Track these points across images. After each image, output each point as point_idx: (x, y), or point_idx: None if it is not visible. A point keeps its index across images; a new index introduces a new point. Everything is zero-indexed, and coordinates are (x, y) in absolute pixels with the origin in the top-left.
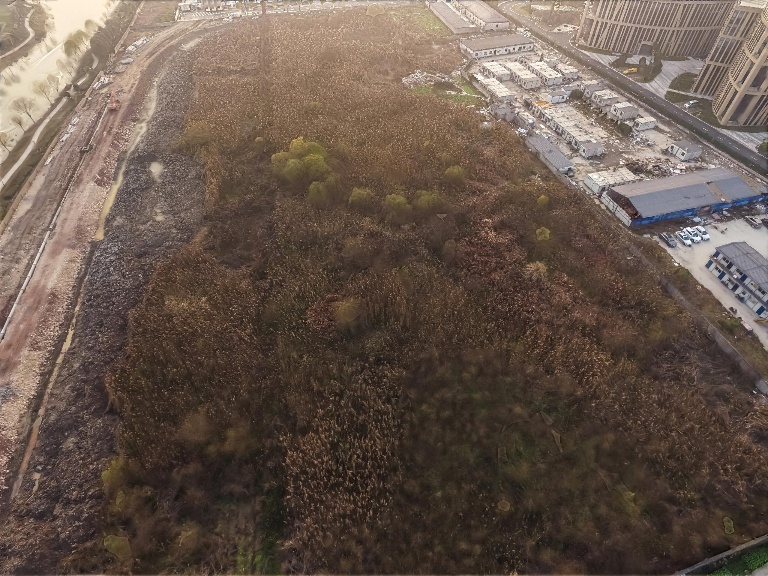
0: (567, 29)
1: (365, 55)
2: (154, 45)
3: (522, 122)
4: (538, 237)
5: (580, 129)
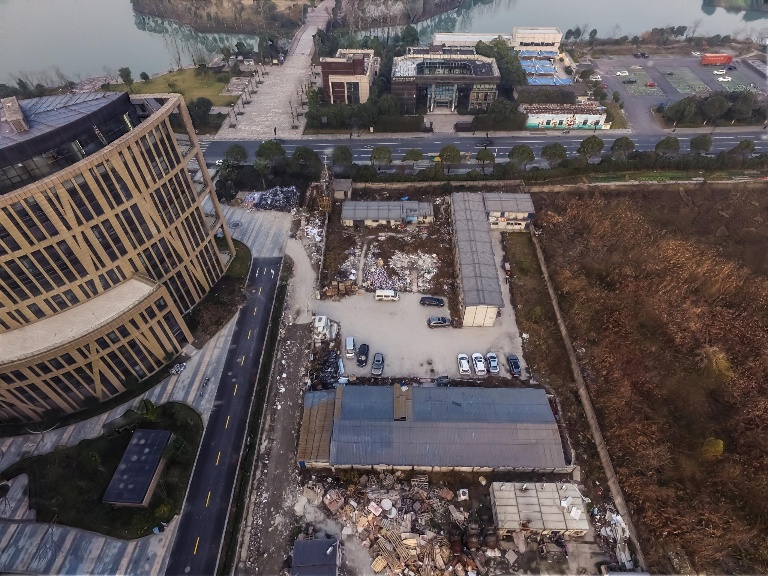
0: None
1: None
2: None
3: None
4: None
5: None
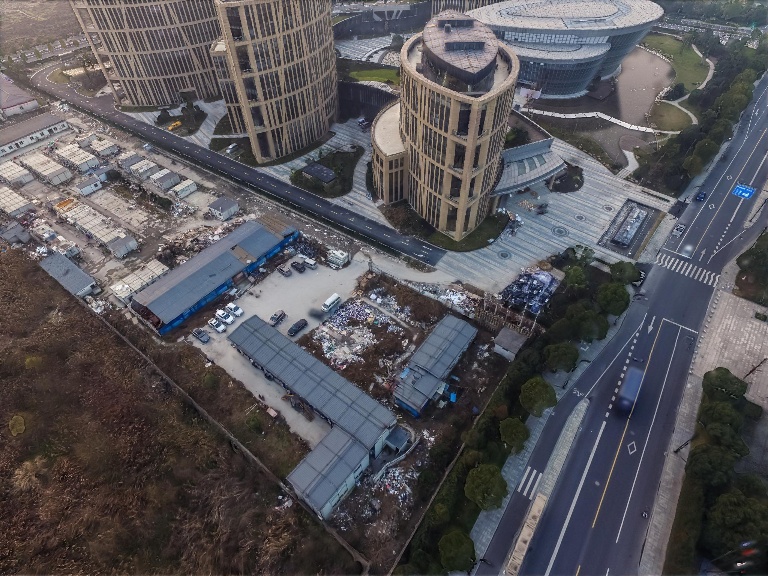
0: (111, 90)
1: None
2: None
3: None
4: (12, 433)
5: (106, 226)
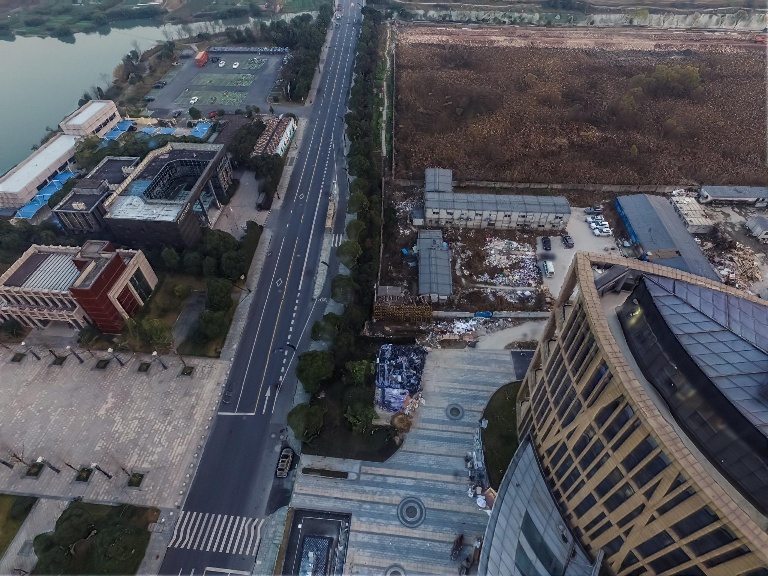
0: None
1: None
2: None
3: None
4: None
5: None
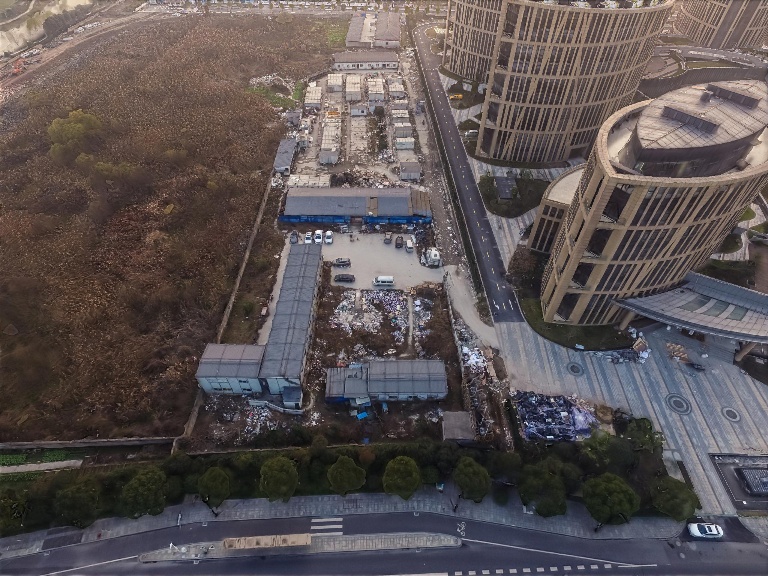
0: None
1: (241, 55)
2: (100, 29)
3: (298, 126)
4: None
5: None
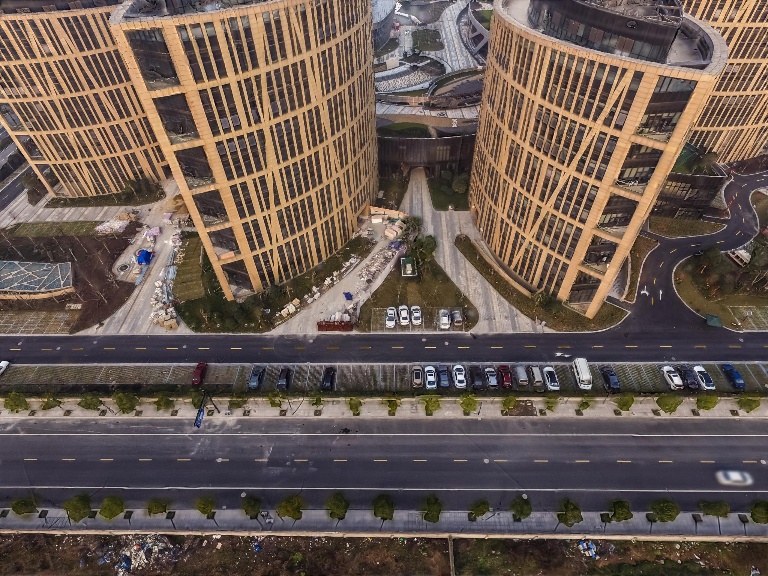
0: None
1: None
2: None
3: None
4: None
5: None
